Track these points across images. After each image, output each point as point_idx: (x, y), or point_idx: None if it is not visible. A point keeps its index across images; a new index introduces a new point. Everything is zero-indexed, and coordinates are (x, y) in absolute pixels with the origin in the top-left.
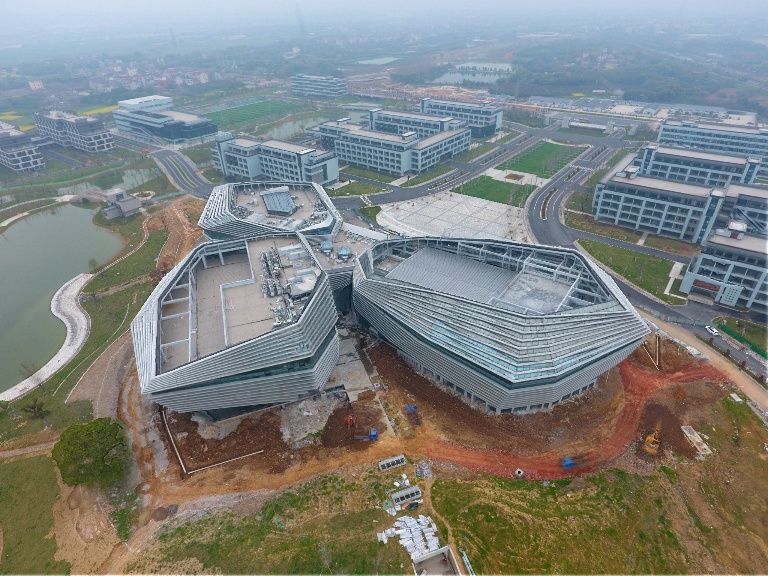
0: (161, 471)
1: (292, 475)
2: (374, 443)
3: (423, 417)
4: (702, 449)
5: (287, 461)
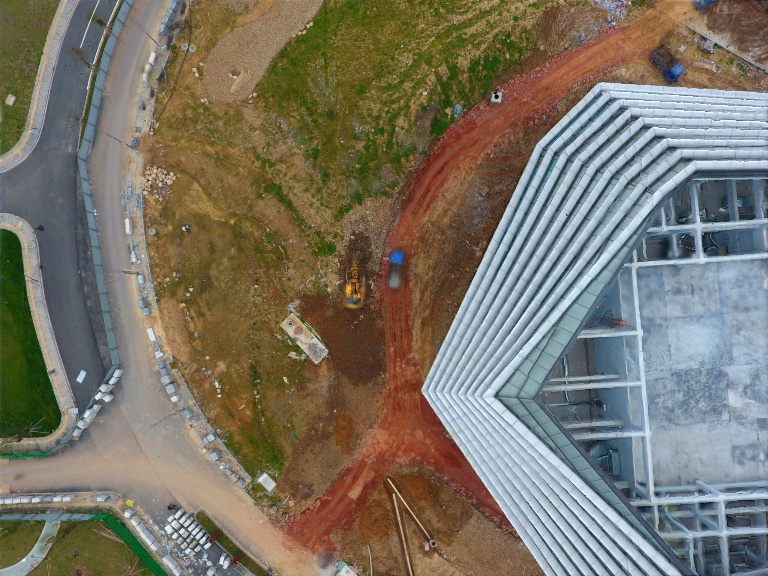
0: None
1: None
2: None
3: (675, 85)
4: (294, 322)
5: None
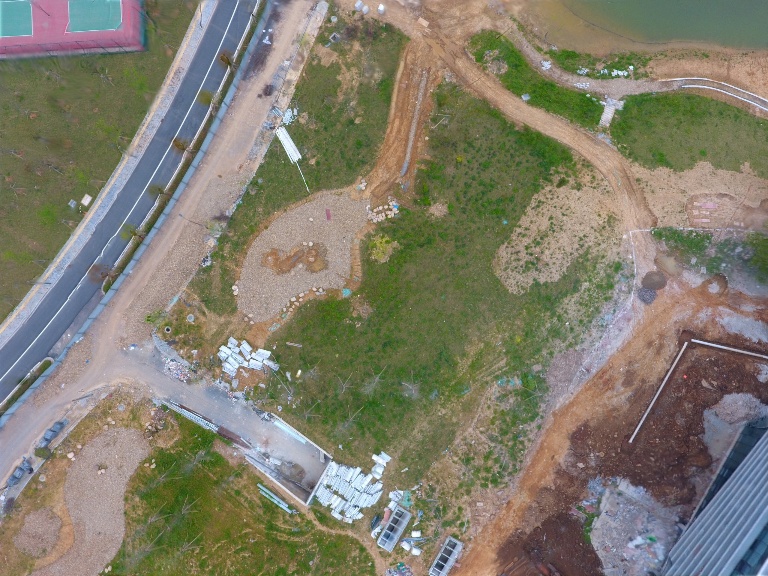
0: (724, 316)
1: (555, 443)
2: (496, 569)
3: None
4: None
5: (581, 455)
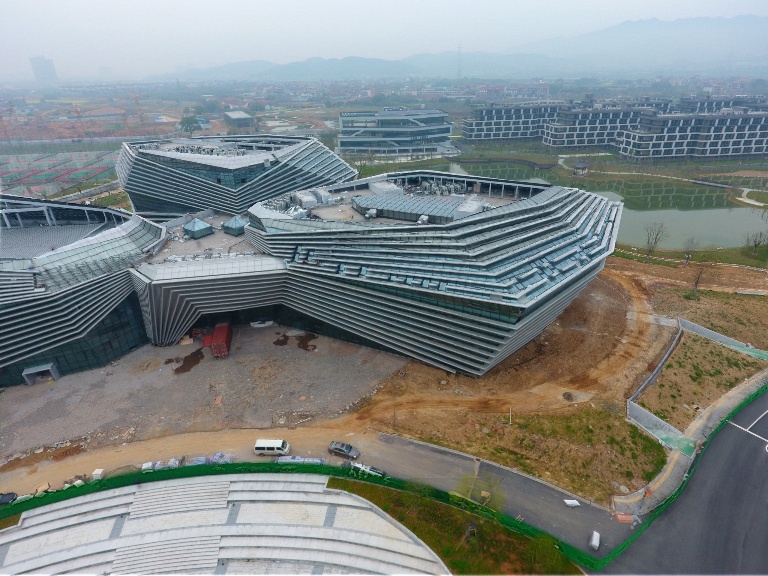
0: None
1: None
2: None
3: None
4: None
5: None
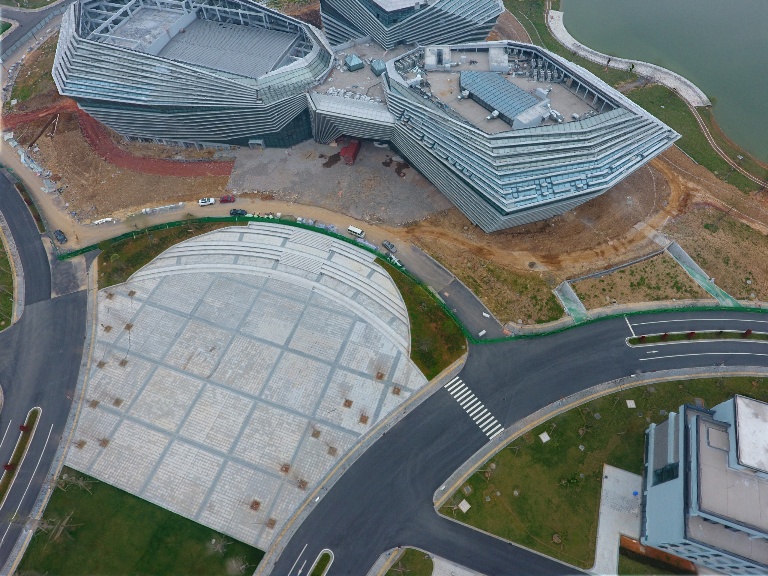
0: None
1: None
2: None
3: None
4: None
5: None
